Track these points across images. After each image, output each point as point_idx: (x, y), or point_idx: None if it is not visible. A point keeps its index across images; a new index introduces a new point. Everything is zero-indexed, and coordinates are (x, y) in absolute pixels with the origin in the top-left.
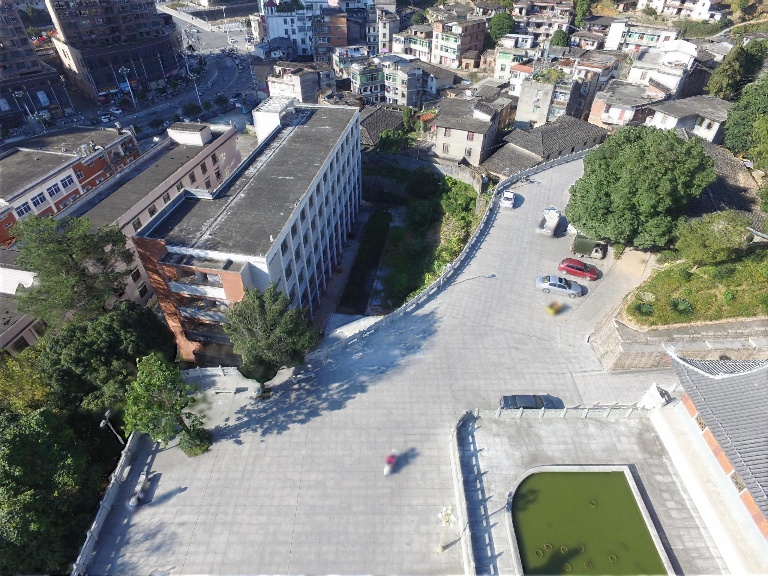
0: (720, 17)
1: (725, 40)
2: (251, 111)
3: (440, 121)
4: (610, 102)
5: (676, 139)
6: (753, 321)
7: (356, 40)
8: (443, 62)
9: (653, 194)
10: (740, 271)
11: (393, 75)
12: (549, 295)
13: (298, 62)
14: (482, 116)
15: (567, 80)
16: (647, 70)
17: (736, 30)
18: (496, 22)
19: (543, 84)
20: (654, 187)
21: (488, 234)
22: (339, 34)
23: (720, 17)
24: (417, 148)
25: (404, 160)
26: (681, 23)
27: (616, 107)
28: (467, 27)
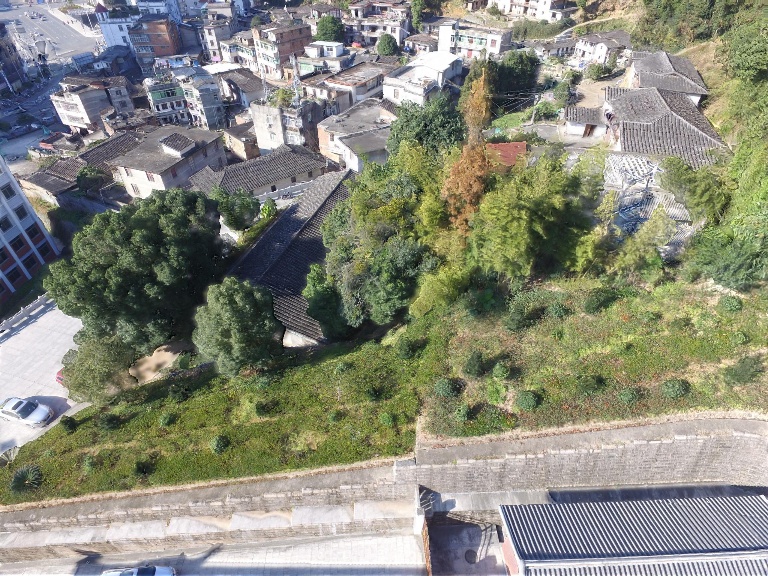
0: (561, 16)
1: (534, 45)
2: (56, 131)
3: (122, 158)
4: (328, 130)
5: (150, 217)
6: (123, 498)
7: (190, 48)
8: (269, 72)
9: (63, 303)
10: (139, 417)
11: (189, 90)
12: (6, 425)
13: (91, 77)
14: (172, 151)
15: (294, 103)
16: (397, 87)
17: (577, 30)
18: (319, 27)
19: (269, 108)
20: (64, 294)
21: (32, 323)
22: (161, 42)
23: (561, 16)
24: (115, 188)
25: (88, 204)
26: (521, 23)
27: (338, 135)
28: (282, 33)
